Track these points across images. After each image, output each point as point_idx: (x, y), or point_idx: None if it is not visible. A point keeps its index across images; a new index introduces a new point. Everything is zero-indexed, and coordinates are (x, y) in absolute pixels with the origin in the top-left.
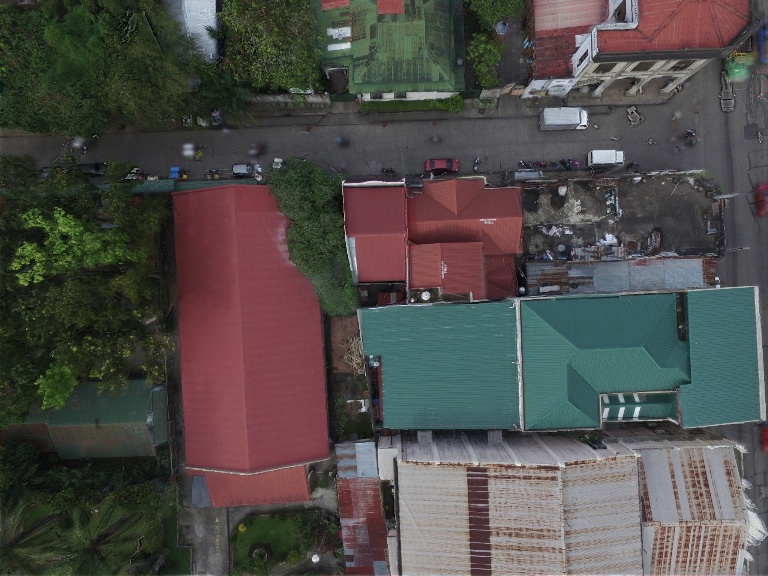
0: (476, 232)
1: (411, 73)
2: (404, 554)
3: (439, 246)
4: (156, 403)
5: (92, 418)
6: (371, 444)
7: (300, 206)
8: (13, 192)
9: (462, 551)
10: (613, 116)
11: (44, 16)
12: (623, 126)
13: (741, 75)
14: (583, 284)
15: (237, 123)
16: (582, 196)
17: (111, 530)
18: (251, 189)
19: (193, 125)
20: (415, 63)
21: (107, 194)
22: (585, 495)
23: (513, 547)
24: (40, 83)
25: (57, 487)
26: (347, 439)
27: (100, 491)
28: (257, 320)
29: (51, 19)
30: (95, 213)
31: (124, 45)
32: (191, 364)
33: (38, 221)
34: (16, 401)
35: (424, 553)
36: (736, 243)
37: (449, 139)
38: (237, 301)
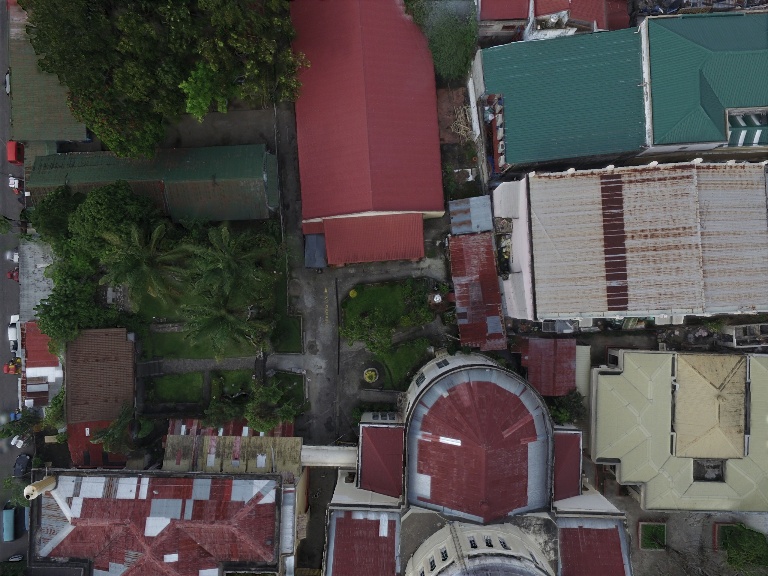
0: None
1: None
2: (537, 267)
3: None
4: (269, 166)
5: (209, 175)
6: (486, 197)
7: None
8: None
9: (596, 258)
10: None
11: None
12: None
13: None
14: None
15: None
16: None
17: None
18: None
19: None
20: None
21: None
22: (717, 199)
23: (648, 248)
24: None
25: None
26: None
27: None
28: (378, 65)
29: None
30: None
31: None
32: (308, 118)
33: None
34: (161, 102)
35: (558, 264)
36: None
37: None
38: (359, 45)
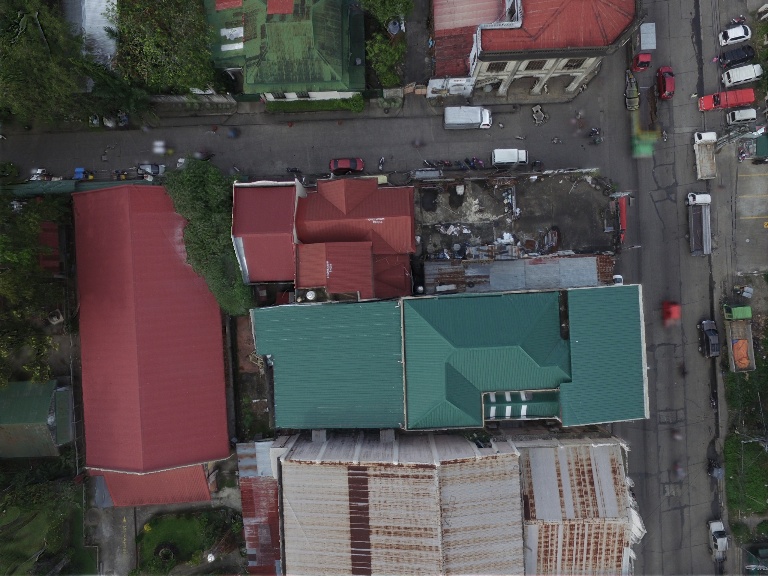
0: (366, 231)
1: (303, 73)
2: (288, 553)
3: (324, 245)
4: (59, 403)
5: None
6: (270, 443)
7: (192, 206)
8: None
9: (343, 550)
10: (518, 115)
11: None
12: (528, 125)
13: (646, 73)
14: (480, 283)
15: (144, 123)
16: (480, 195)
17: (2, 530)
18: (146, 189)
19: (99, 126)
20: (306, 63)
21: None
22: (464, 493)
23: (392, 546)
24: None
25: None
26: (252, 438)
27: None
28: (152, 320)
29: None
30: None
31: (12, 46)
32: (90, 364)
33: None
34: None
35: (307, 552)
36: (641, 241)
37: (355, 139)
38: (131, 301)
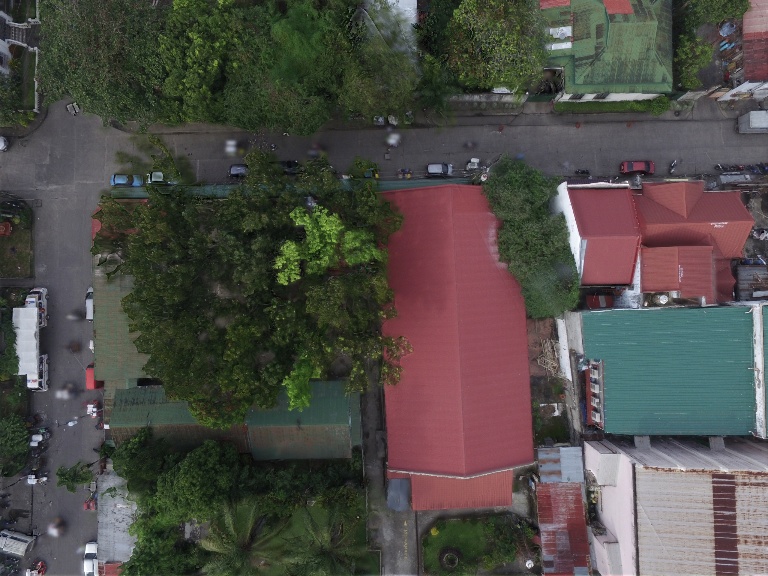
0: (703, 236)
1: (635, 74)
2: (642, 561)
3: (676, 249)
4: (353, 404)
5: (293, 419)
6: (577, 449)
7: (521, 207)
8: (274, 189)
9: (706, 559)
10: None
11: (269, 11)
12: None
13: None
14: None
15: (428, 122)
16: None
17: None
18: (466, 189)
19: (384, 124)
20: (640, 64)
21: (362, 193)
22: None
23: (763, 556)
24: (268, 79)
25: (261, 489)
26: (542, 443)
27: (304, 493)
28: (472, 322)
29: (274, 15)
30: (352, 212)
31: (354, 42)
32: None
33: (305, 219)
34: (264, 402)
35: (664, 561)
36: None
37: (643, 141)
38: (454, 302)
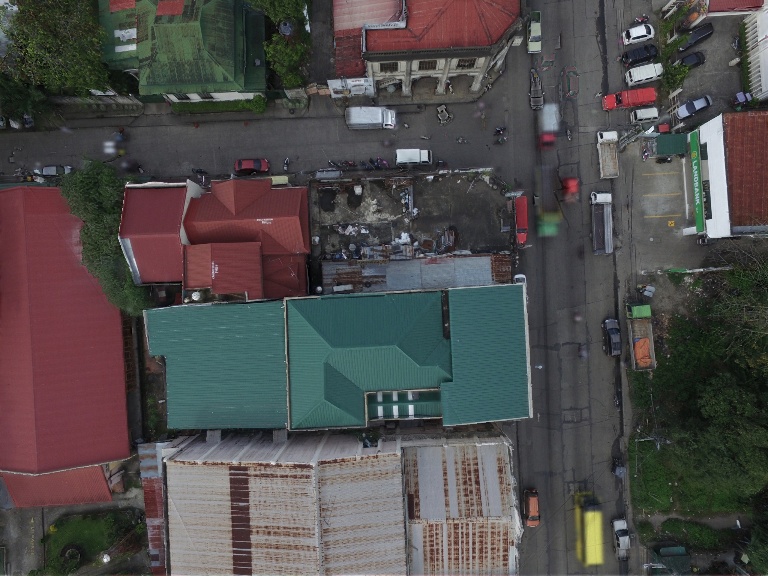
0: (256, 232)
1: (195, 74)
2: (173, 553)
3: (209, 246)
4: None
5: None
6: None
7: (85, 207)
8: None
9: (225, 550)
10: (423, 115)
11: None
12: (433, 125)
13: (550, 73)
14: (376, 283)
15: (51, 125)
16: (379, 195)
17: None
18: (41, 191)
19: (6, 127)
20: (197, 64)
21: None
22: (345, 493)
23: (271, 545)
24: None
25: None
26: (157, 439)
27: None
28: (47, 321)
29: None
30: None
31: None
32: None
33: None
34: None
35: (191, 552)
36: (545, 241)
37: (261, 139)
38: (26, 303)
